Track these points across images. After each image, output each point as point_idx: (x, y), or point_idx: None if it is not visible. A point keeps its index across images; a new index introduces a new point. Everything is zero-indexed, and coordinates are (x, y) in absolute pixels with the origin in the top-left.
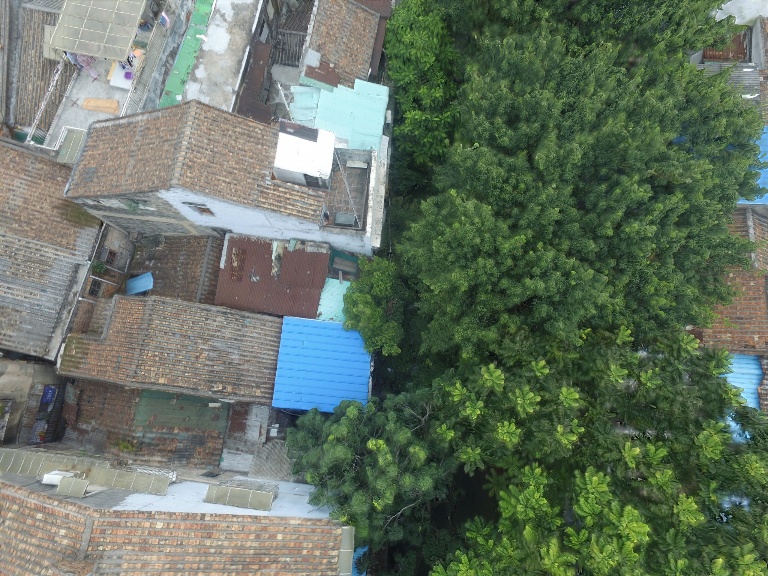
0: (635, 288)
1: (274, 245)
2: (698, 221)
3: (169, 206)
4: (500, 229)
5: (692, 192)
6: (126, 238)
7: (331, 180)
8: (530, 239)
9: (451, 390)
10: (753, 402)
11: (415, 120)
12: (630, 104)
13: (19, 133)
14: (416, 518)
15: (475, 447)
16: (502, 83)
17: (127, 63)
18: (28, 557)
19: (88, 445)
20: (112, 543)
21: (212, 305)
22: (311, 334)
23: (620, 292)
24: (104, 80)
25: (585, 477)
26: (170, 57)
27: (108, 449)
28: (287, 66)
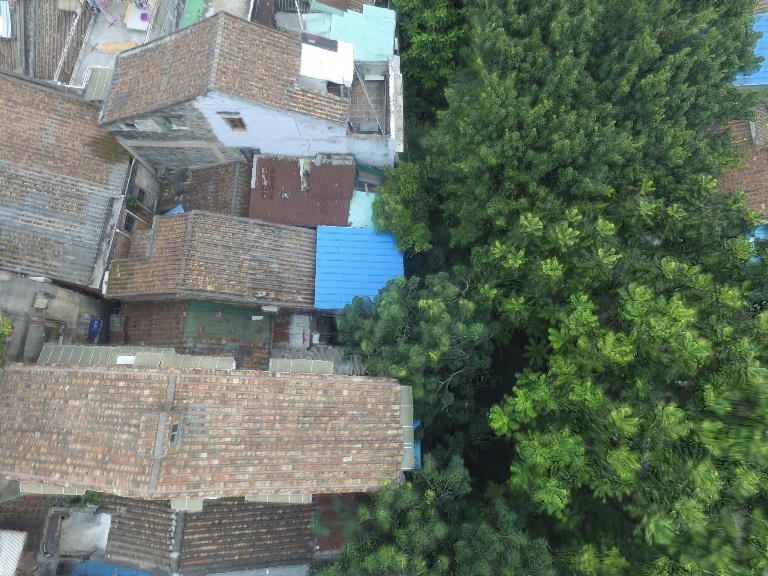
0: (651, 149)
1: (301, 162)
2: (705, 79)
3: (203, 121)
4: (522, 102)
5: (698, 47)
6: (153, 178)
7: (351, 94)
8: (550, 113)
9: (491, 250)
10: None
11: (422, 42)
12: None
13: None
14: (462, 396)
15: (519, 298)
16: None
17: (144, 1)
18: (115, 420)
19: None
20: (194, 397)
21: (249, 218)
22: (345, 240)
23: (638, 152)
24: (120, 25)
25: (628, 289)
26: (181, 1)
27: None
28: (289, 13)
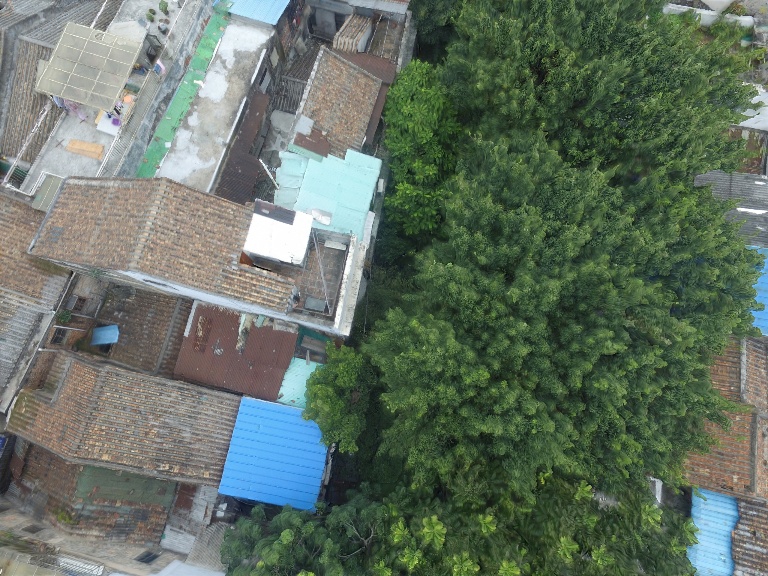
0: (604, 433)
1: (242, 318)
2: (678, 372)
3: (132, 278)
4: (466, 356)
5: (673, 347)
6: (99, 283)
7: (307, 259)
8: None
9: (393, 528)
10: (725, 546)
11: (406, 195)
12: (618, 240)
13: (4, 164)
14: None
15: None
16: (490, 189)
17: (113, 113)
18: None
19: (28, 507)
20: None
21: (168, 379)
22: (268, 418)
23: (586, 437)
24: (92, 122)
25: None
26: (163, 103)
27: (46, 516)
28: (288, 113)
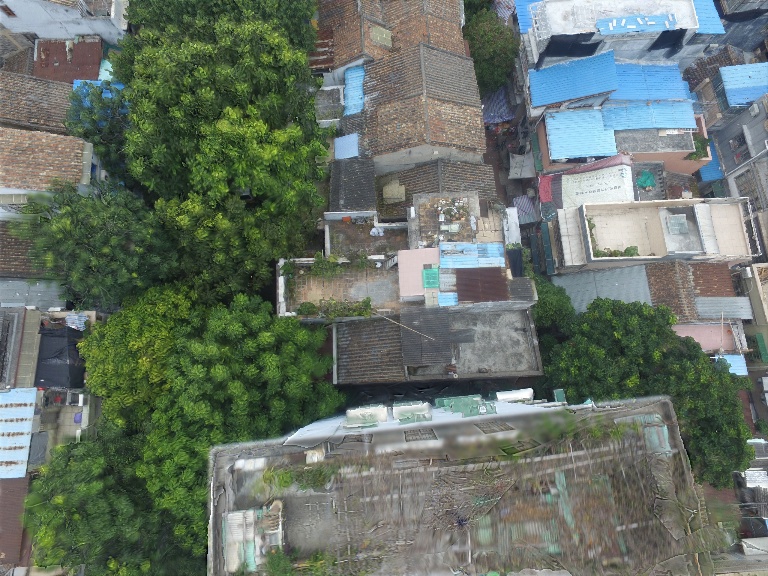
0: None
1: (67, 43)
2: None
3: None
4: None
5: None
6: None
7: None
8: None
9: None
10: (361, 90)
11: None
12: None
13: None
14: None
15: None
16: None
17: None
18: None
19: None
20: None
21: None
22: None
23: (228, 5)
24: None
25: None
26: None
27: None
28: None
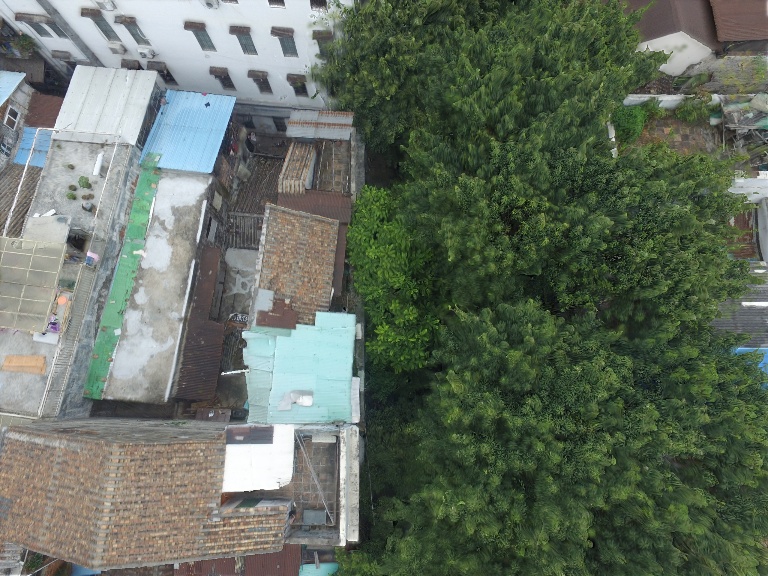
0: None
1: None
2: None
3: None
4: None
5: None
6: None
7: (295, 459)
8: None
9: None
10: None
11: (388, 342)
12: (644, 443)
13: None
14: None
15: None
16: (485, 374)
17: (48, 329)
18: None
19: None
20: None
21: None
22: None
23: None
24: (27, 331)
25: None
26: (103, 289)
27: None
28: (243, 249)
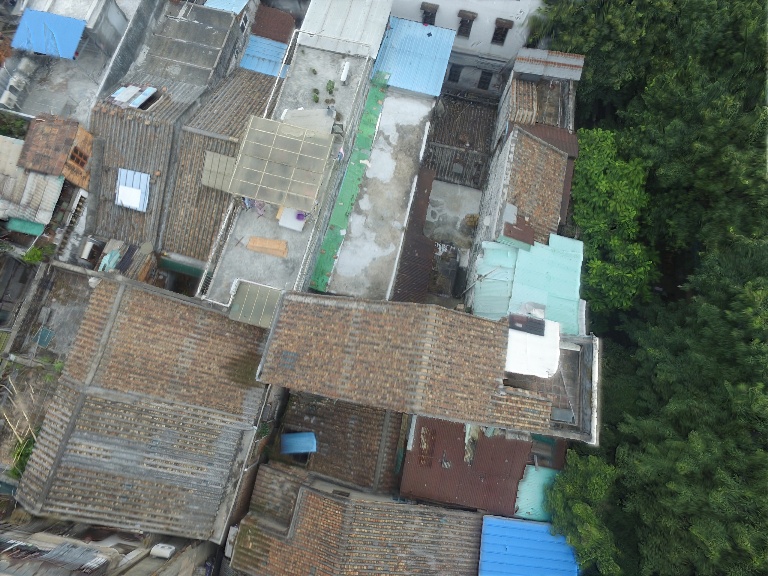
0: None
1: (467, 426)
2: None
3: None
4: None
5: None
6: None
7: None
8: None
9: None
10: None
11: (605, 275)
12: None
13: (166, 261)
14: None
15: None
16: None
17: None
18: None
19: None
20: None
21: (410, 505)
22: (513, 537)
23: None
24: (270, 217)
25: None
26: (337, 189)
27: None
28: (435, 180)
